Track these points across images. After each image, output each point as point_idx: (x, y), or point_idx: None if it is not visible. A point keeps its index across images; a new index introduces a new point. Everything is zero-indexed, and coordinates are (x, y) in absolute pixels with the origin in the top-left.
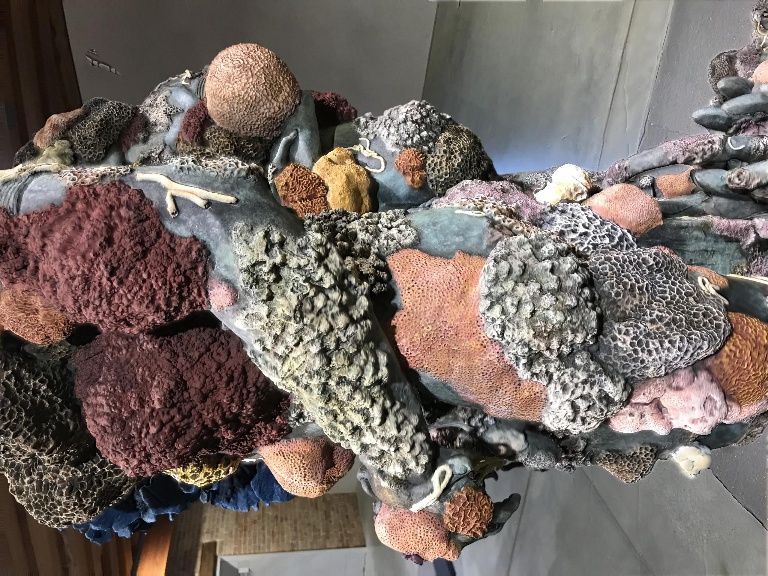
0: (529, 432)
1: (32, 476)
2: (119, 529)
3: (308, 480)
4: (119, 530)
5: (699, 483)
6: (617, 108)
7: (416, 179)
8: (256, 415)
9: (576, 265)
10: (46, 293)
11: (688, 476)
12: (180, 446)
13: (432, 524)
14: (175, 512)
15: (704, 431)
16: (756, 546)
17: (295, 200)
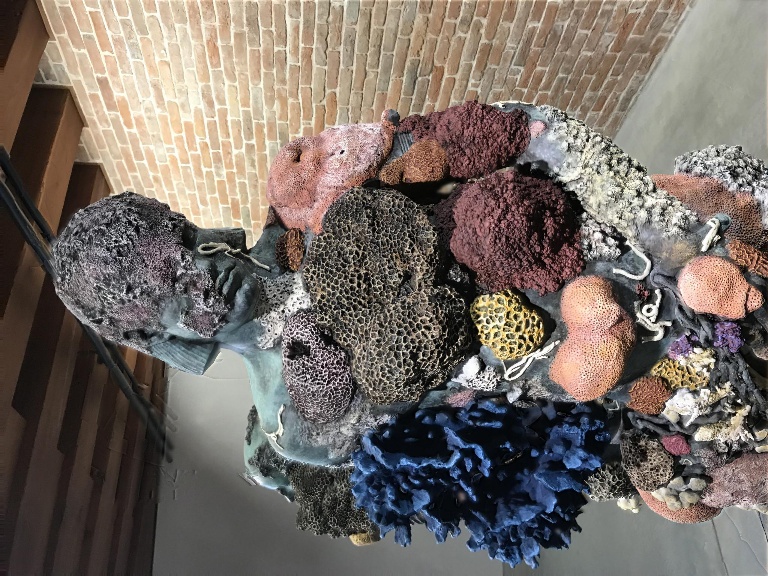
0: None
1: (397, 305)
2: (430, 460)
3: (610, 304)
4: (430, 461)
5: None
6: (720, 522)
7: None
8: (564, 221)
9: None
10: (442, 132)
11: None
12: (528, 202)
13: (725, 260)
14: (480, 447)
15: None
16: None
17: None
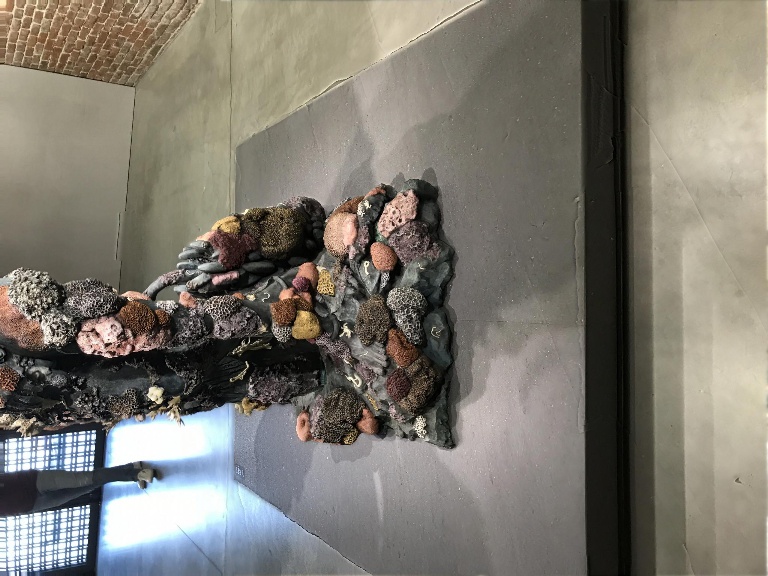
0: (54, 370)
1: None
2: None
3: None
4: None
5: (309, 553)
6: None
7: None
8: None
9: (50, 278)
10: None
11: (304, 553)
12: None
13: None
14: None
15: (114, 339)
16: (337, 573)
17: None
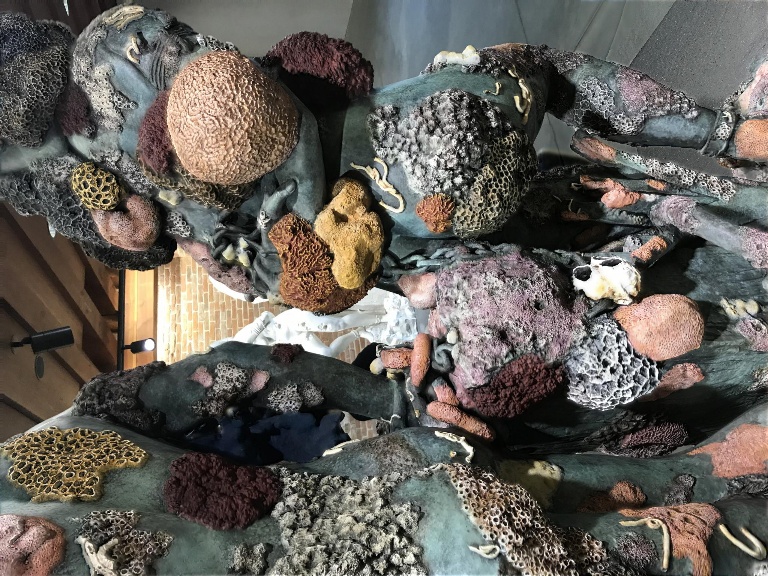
0: None
1: None
2: None
3: None
4: None
5: None
6: None
7: (440, 229)
8: None
9: None
10: None
11: None
12: None
13: None
14: None
15: None
16: None
17: (295, 276)
